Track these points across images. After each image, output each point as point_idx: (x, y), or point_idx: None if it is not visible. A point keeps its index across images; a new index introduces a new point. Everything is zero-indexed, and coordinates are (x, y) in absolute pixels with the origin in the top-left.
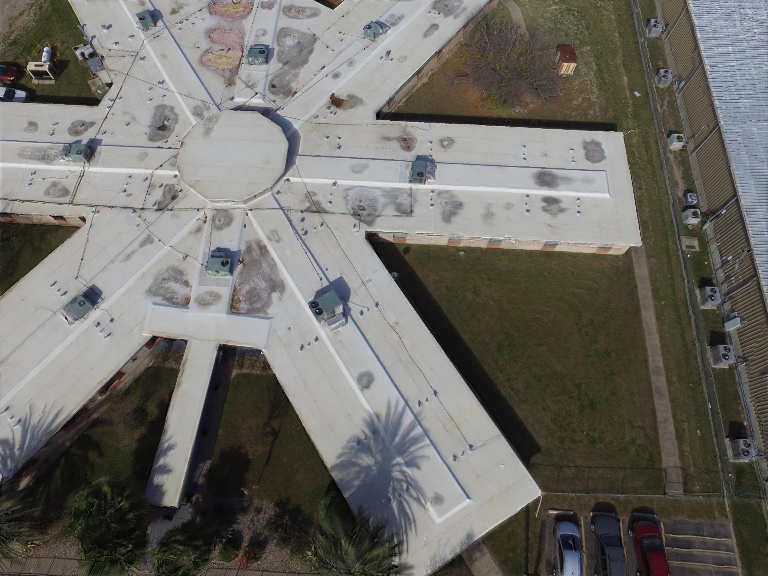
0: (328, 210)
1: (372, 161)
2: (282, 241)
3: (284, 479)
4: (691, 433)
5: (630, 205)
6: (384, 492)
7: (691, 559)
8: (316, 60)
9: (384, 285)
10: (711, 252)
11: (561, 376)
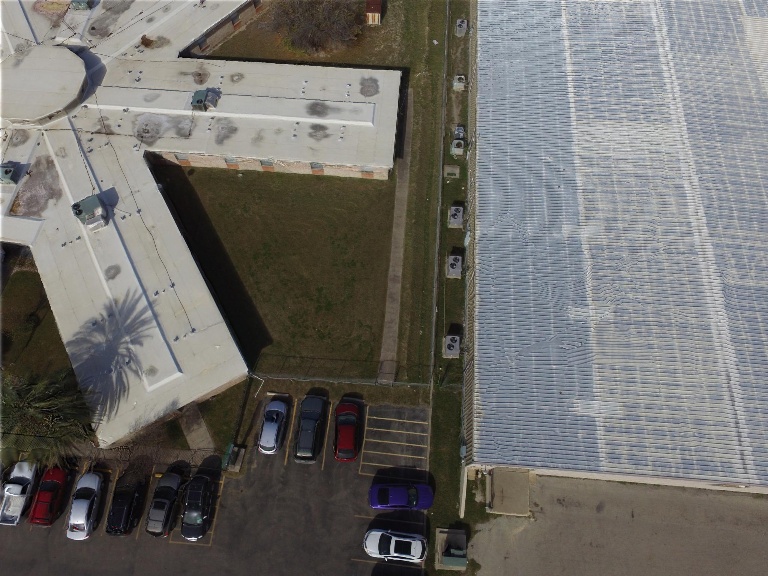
0: (115, 132)
1: (164, 92)
2: (67, 157)
3: (39, 359)
4: (413, 332)
5: (390, 133)
6: (108, 365)
7: (388, 438)
8: (136, 7)
9: (150, 195)
10: (468, 178)
11: (306, 281)
